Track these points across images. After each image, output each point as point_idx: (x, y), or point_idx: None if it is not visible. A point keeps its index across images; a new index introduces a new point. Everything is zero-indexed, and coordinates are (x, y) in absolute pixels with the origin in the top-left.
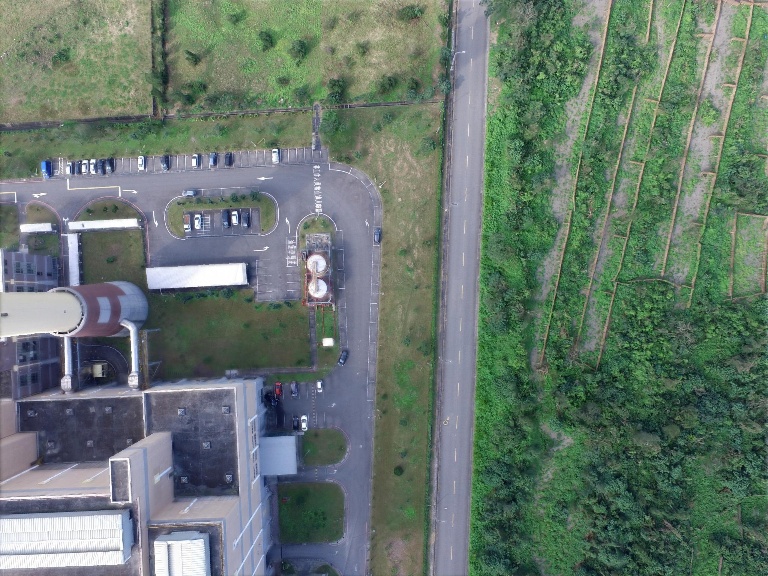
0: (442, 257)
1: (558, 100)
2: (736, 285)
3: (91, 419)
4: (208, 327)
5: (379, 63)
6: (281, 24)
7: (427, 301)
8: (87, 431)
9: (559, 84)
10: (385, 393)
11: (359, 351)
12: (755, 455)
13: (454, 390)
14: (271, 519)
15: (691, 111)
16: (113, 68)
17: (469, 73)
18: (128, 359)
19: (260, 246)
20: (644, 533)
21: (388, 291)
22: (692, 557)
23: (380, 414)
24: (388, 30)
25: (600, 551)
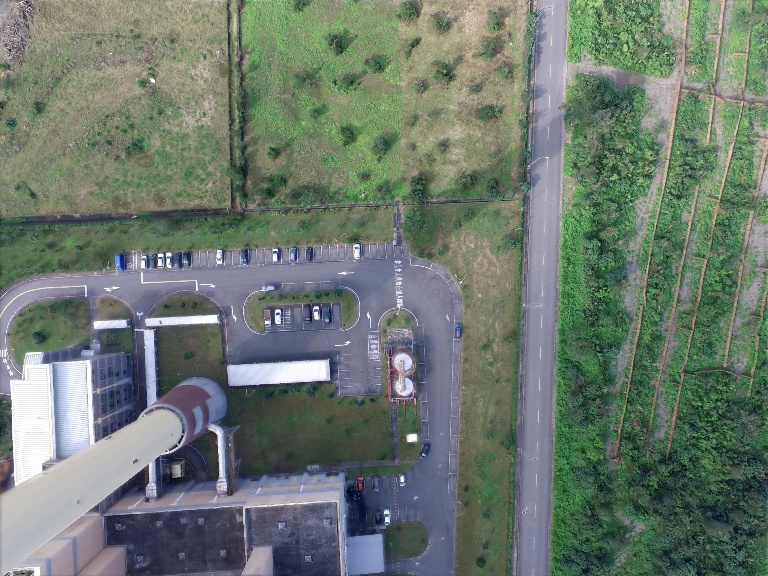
0: (520, 351)
1: (629, 200)
2: None
3: (182, 531)
4: (289, 423)
5: (459, 160)
6: (362, 119)
7: (506, 394)
8: (178, 543)
9: (631, 185)
10: (466, 485)
11: (440, 444)
12: None
13: (532, 480)
14: None
15: (749, 210)
16: (190, 160)
17: (545, 172)
18: (206, 456)
19: (341, 341)
20: None
21: (469, 385)
22: None
23: (461, 506)
24: (467, 128)
25: None
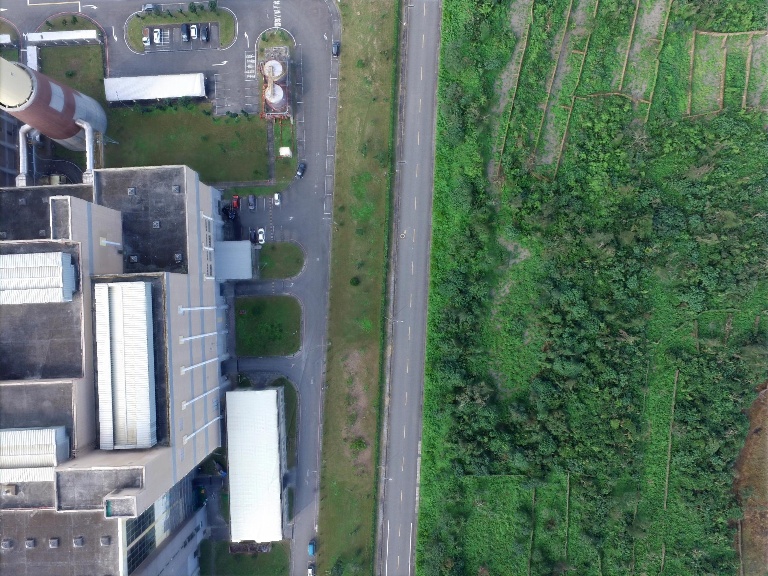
0: (400, 71)
1: None
2: (694, 104)
3: (43, 209)
4: (166, 141)
5: None
6: None
7: (385, 114)
8: (39, 221)
9: None
10: (342, 206)
11: (317, 164)
12: (711, 267)
13: (411, 203)
14: (228, 332)
15: None
16: None
17: None
18: None
19: (219, 60)
20: (599, 340)
21: (346, 104)
22: (648, 368)
23: (337, 227)
24: None
25: (555, 359)
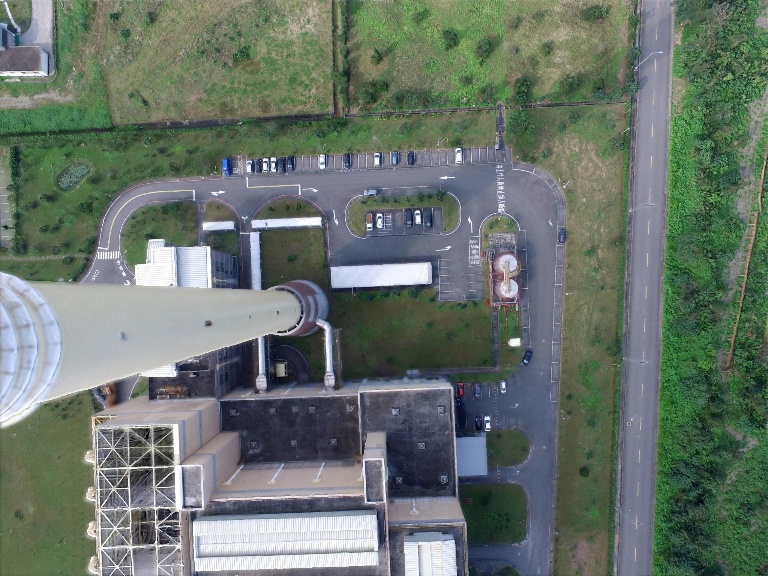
0: (626, 258)
1: (744, 101)
2: None
3: (294, 419)
4: (390, 327)
5: (563, 63)
6: (464, 23)
7: (612, 302)
8: (290, 431)
9: (745, 85)
10: (569, 394)
11: (542, 351)
12: None
13: (638, 391)
14: None
15: None
16: (294, 66)
17: (653, 74)
18: (308, 358)
19: (442, 246)
20: None
21: (572, 291)
22: None
23: (564, 415)
24: (572, 30)
25: None
